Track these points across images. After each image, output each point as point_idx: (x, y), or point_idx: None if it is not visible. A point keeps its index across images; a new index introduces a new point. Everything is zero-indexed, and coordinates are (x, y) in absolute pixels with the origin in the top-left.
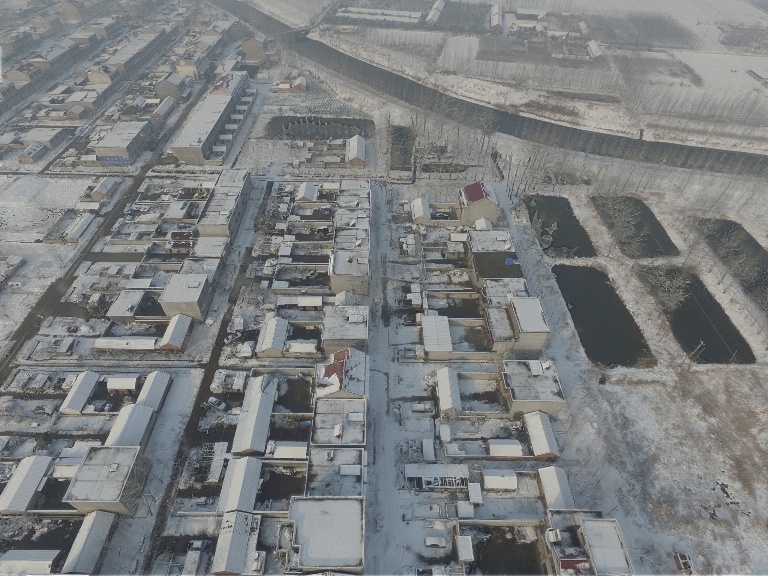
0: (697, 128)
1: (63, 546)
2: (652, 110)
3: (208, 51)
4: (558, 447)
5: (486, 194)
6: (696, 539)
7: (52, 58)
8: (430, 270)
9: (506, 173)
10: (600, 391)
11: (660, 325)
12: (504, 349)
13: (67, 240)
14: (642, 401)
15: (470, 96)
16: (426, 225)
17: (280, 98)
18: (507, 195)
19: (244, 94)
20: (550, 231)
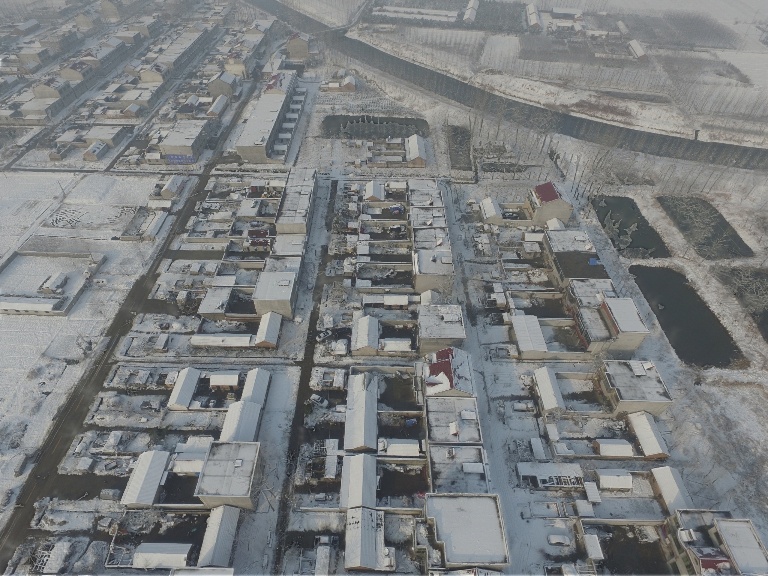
0: (753, 129)
1: (191, 540)
2: (704, 110)
3: (254, 50)
4: (667, 447)
5: (559, 194)
6: None
7: (102, 56)
8: (508, 270)
9: (567, 173)
10: (697, 392)
11: (747, 326)
12: (599, 349)
13: (144, 238)
14: (741, 402)
15: (519, 96)
16: (497, 225)
17: (330, 97)
18: (572, 195)
19: (294, 93)
20: (629, 232)
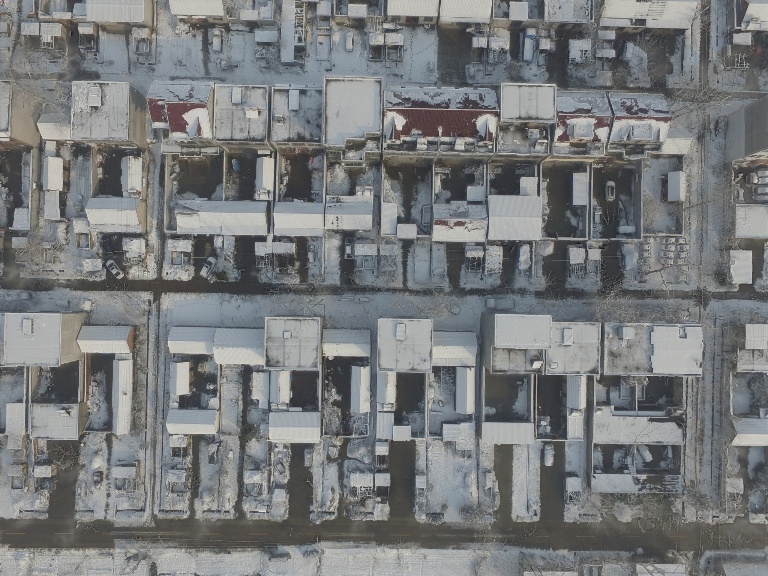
0: None
1: (347, 369)
2: None
3: None
4: None
5: None
6: None
7: None
8: None
9: None
10: None
11: None
12: None
13: None
14: None
15: None
16: None
17: None
18: None
19: None
20: None
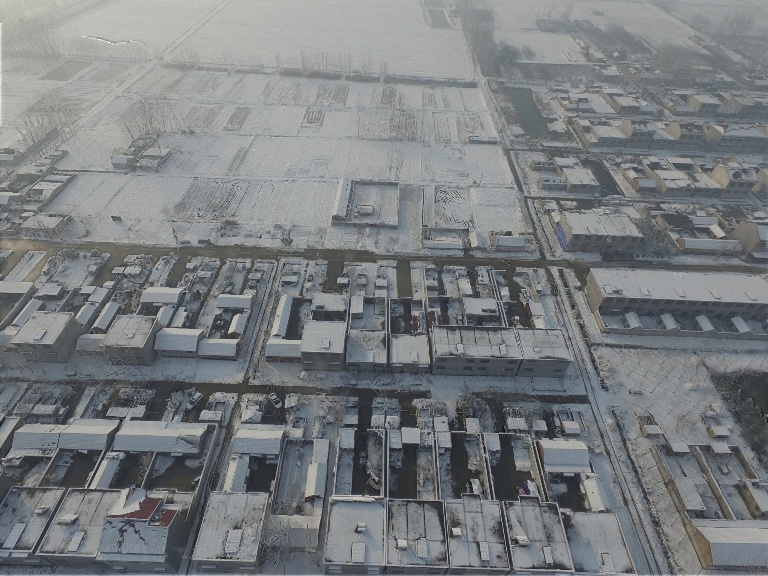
0: None
1: None
2: None
3: None
4: None
5: None
6: None
7: (733, 134)
8: None
9: None
10: None
11: None
12: None
13: None
14: None
15: None
16: None
17: None
18: None
19: None
20: None
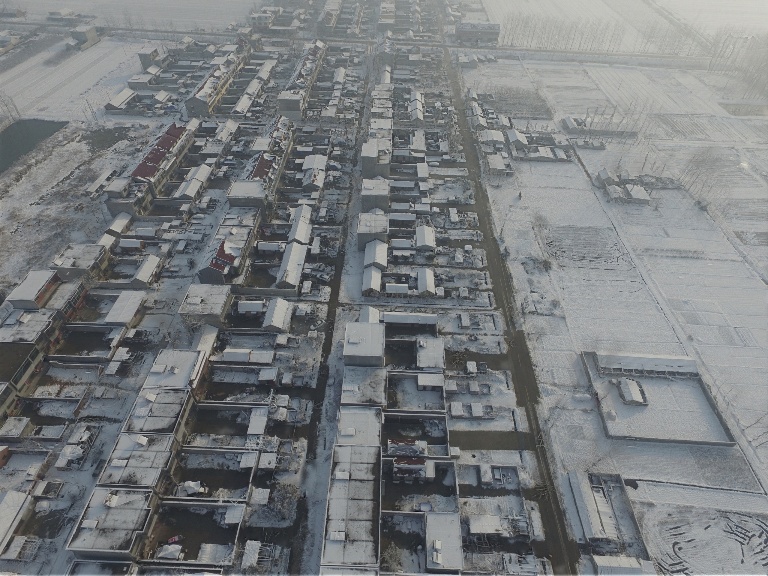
0: None
1: None
2: None
3: None
4: None
5: None
6: (61, 215)
7: None
8: None
9: None
10: None
11: None
12: None
13: None
14: (2, 271)
15: None
16: None
17: None
18: None
19: None
20: None
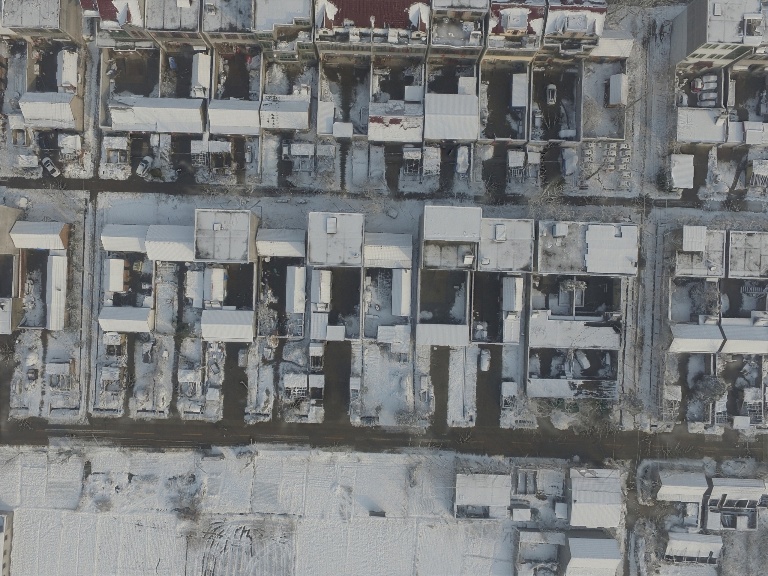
0: None
1: (283, 271)
2: None
3: None
4: None
5: None
6: None
7: None
8: None
9: None
10: None
11: None
12: None
13: None
14: None
15: None
16: None
17: None
18: None
19: None
20: None
